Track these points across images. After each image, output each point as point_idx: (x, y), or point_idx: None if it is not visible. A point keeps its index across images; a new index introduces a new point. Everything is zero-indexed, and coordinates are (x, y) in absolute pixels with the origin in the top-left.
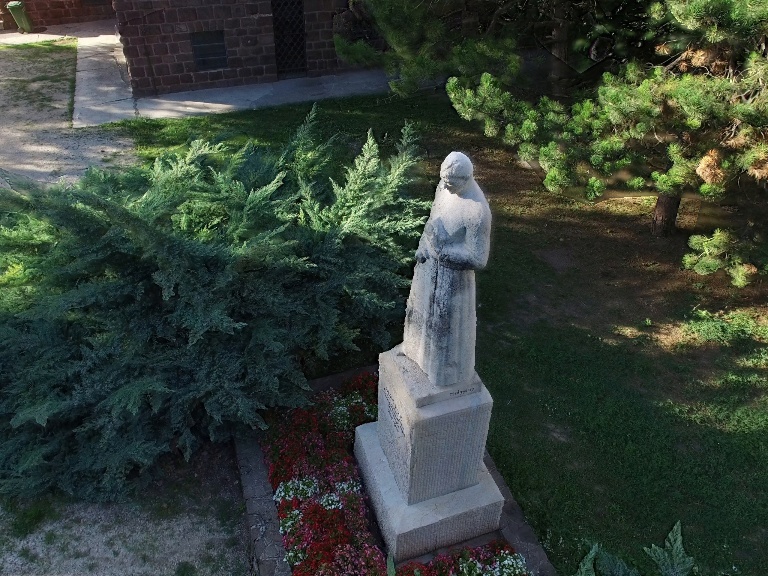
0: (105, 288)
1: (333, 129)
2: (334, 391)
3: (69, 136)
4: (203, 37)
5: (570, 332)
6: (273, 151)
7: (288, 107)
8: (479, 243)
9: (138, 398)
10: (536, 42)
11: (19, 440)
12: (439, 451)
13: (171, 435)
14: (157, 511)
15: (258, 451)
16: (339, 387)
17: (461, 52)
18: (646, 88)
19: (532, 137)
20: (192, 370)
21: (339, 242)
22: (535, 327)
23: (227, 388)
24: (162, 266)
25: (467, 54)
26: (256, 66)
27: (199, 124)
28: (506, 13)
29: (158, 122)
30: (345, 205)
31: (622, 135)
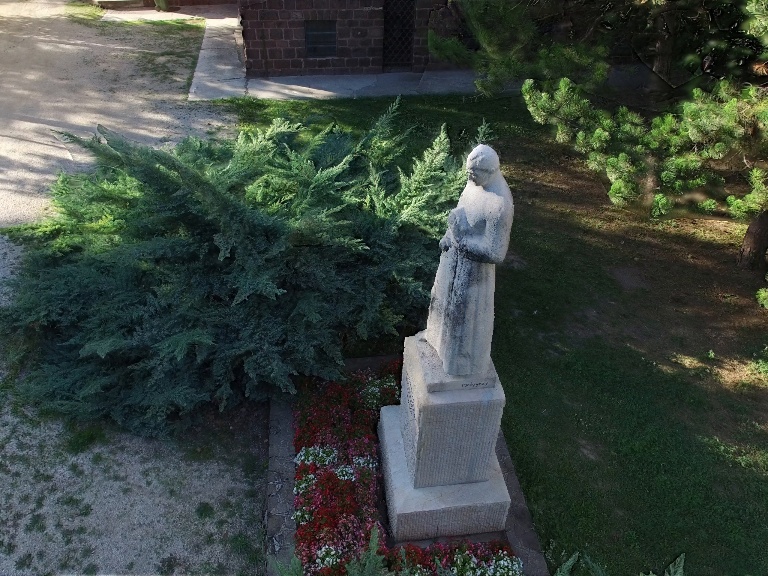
0: (174, 243)
1: (412, 121)
2: (371, 371)
3: (183, 107)
4: (317, 25)
5: (623, 352)
6: (354, 137)
7: (387, 99)
8: (497, 237)
9: (185, 346)
10: (632, 52)
11: (86, 370)
12: (447, 439)
13: (212, 386)
14: (191, 453)
15: (289, 415)
16: (377, 369)
17: (548, 56)
18: (733, 107)
19: (603, 147)
20: (239, 329)
21: (395, 229)
22: (587, 342)
23: (265, 350)
24: (224, 229)
25: (554, 58)
26: (363, 57)
27: (300, 107)
28: (607, 21)
29: (263, 102)
30: (408, 194)
31: (701, 154)
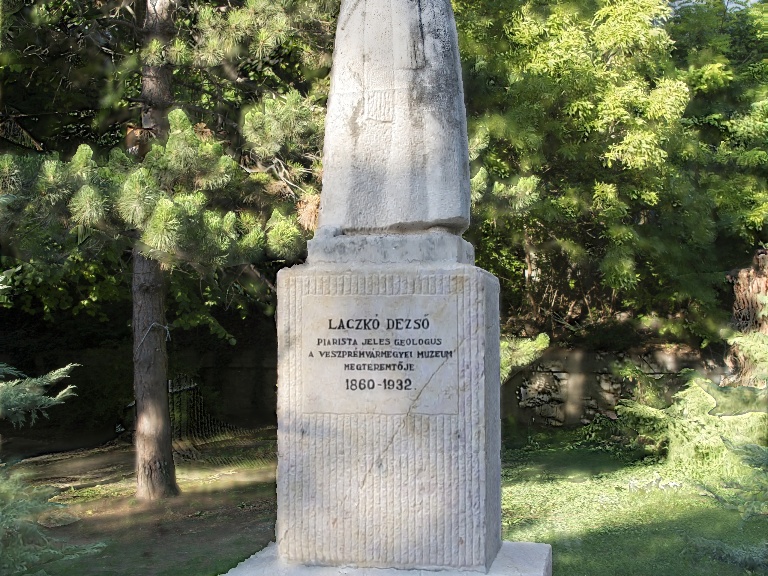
0: None
1: None
2: None
3: None
4: None
5: None
6: None
7: None
8: None
9: None
10: None
11: None
12: None
13: None
14: None
15: None
16: None
17: None
18: None
19: (93, 176)
20: None
21: None
22: (171, 573)
23: None
24: None
25: None
26: None
27: None
28: None
29: None
30: None
31: None
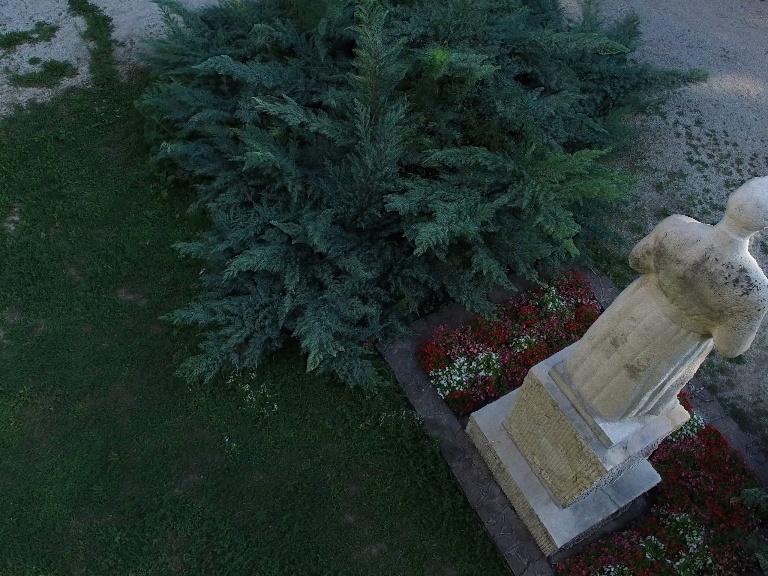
0: None
1: None
2: None
3: None
4: None
5: None
6: None
7: None
8: None
9: None
10: None
11: None
12: None
13: None
14: None
15: None
16: None
17: None
18: None
19: None
20: None
21: None
22: None
23: None
24: None
25: None
26: None
27: None
28: None
29: None
30: None
31: None
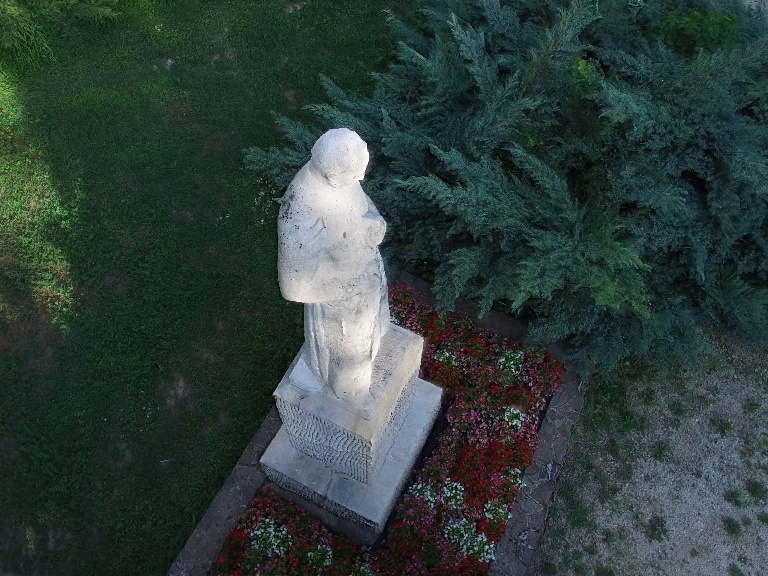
0: None
1: None
2: None
3: None
4: None
5: None
6: None
7: None
8: None
9: None
10: None
11: None
12: None
13: None
14: None
15: None
16: None
17: None
18: None
19: None
20: None
21: None
22: None
23: None
24: None
25: None
26: None
27: None
28: None
29: None
30: None
31: None
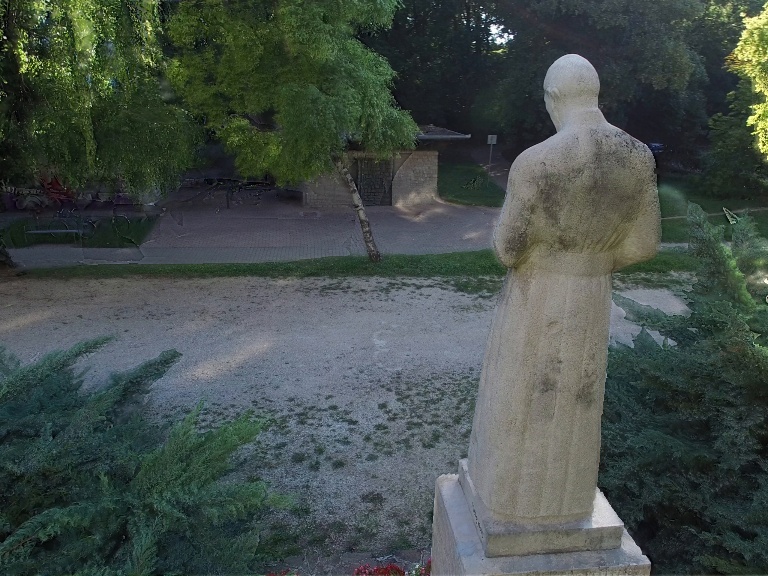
0: (681, 329)
1: None
2: None
3: None
4: None
5: None
6: None
7: None
8: None
9: None
10: None
11: None
12: None
13: None
14: None
15: None
16: None
17: None
18: None
19: None
20: None
21: None
22: None
23: None
24: None
25: None
26: None
27: None
28: None
29: None
30: None
31: None
